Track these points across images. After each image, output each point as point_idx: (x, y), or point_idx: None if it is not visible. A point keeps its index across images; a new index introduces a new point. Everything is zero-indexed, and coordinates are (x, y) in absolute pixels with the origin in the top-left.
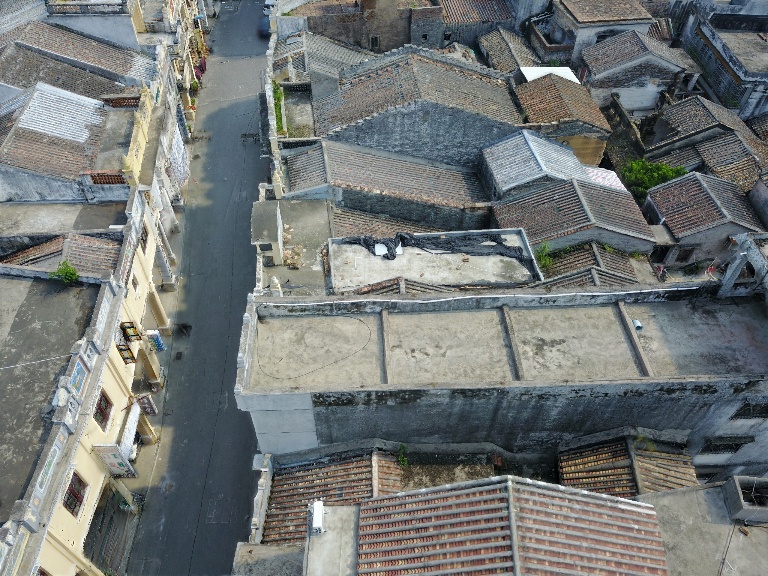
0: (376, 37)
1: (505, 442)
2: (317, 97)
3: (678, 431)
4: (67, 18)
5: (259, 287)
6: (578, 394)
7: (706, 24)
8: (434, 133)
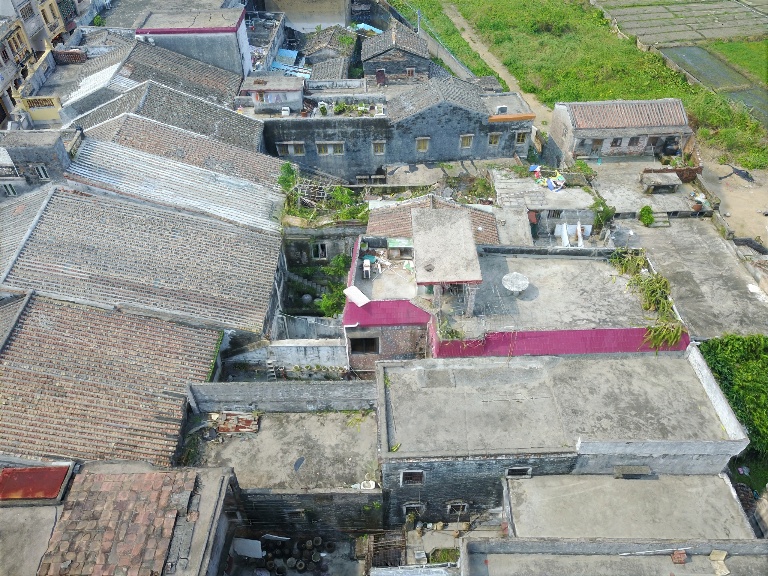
0: None
1: None
2: None
3: None
4: None
5: (3, 21)
6: None
7: None
8: None
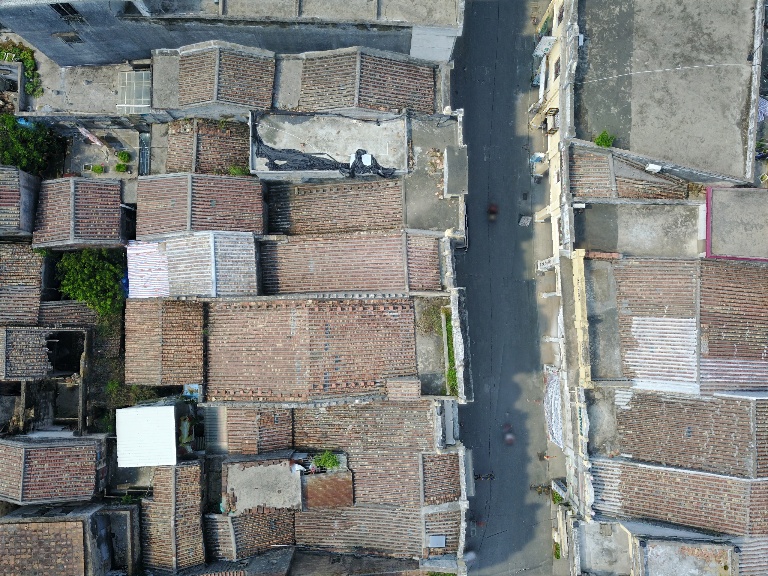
0: None
1: None
2: None
3: None
4: None
5: (460, 116)
6: None
7: None
8: None
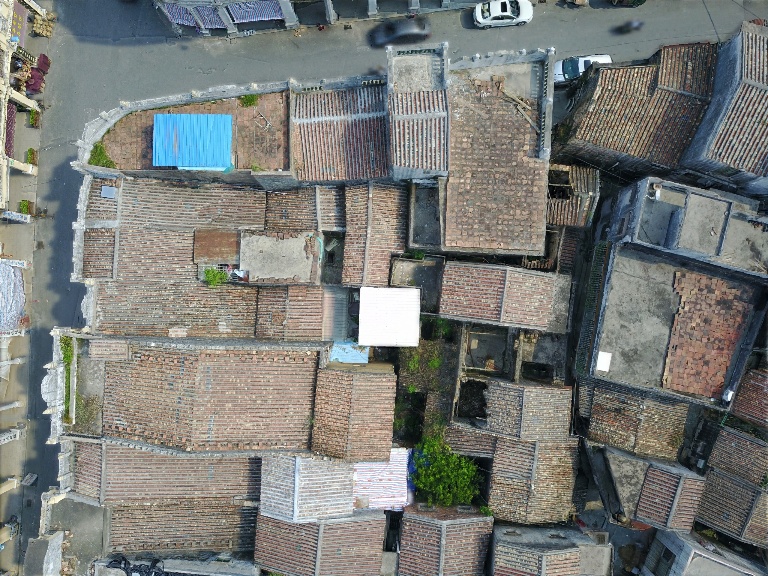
0: (216, 177)
1: None
2: None
3: None
4: None
5: None
6: None
7: (614, 253)
8: None
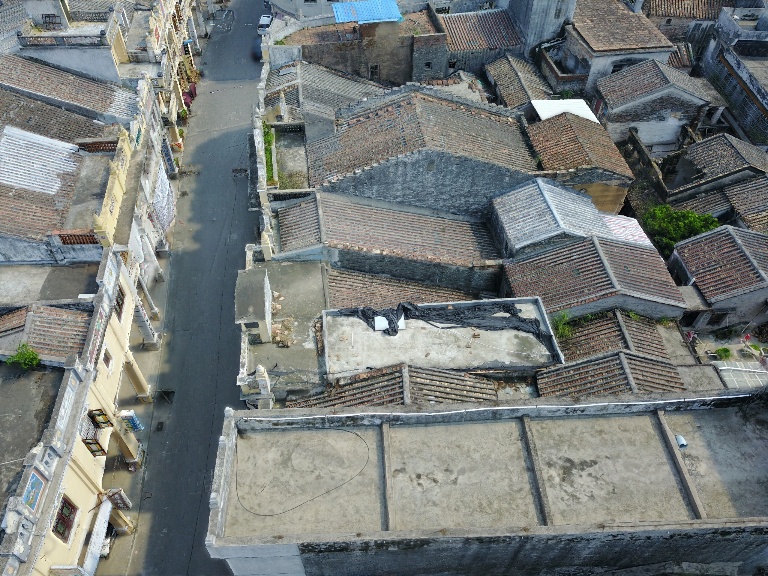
0: (376, 66)
1: (526, 575)
2: (311, 139)
3: (728, 563)
4: (42, 51)
5: (243, 374)
6: (616, 538)
7: (730, 51)
8: (439, 183)
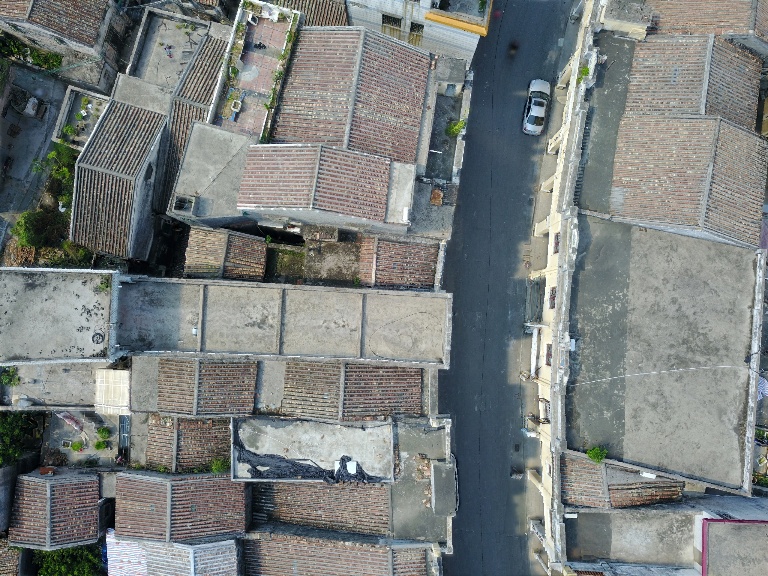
0: None
1: None
2: None
3: None
4: None
5: (447, 427)
6: None
7: None
8: None
